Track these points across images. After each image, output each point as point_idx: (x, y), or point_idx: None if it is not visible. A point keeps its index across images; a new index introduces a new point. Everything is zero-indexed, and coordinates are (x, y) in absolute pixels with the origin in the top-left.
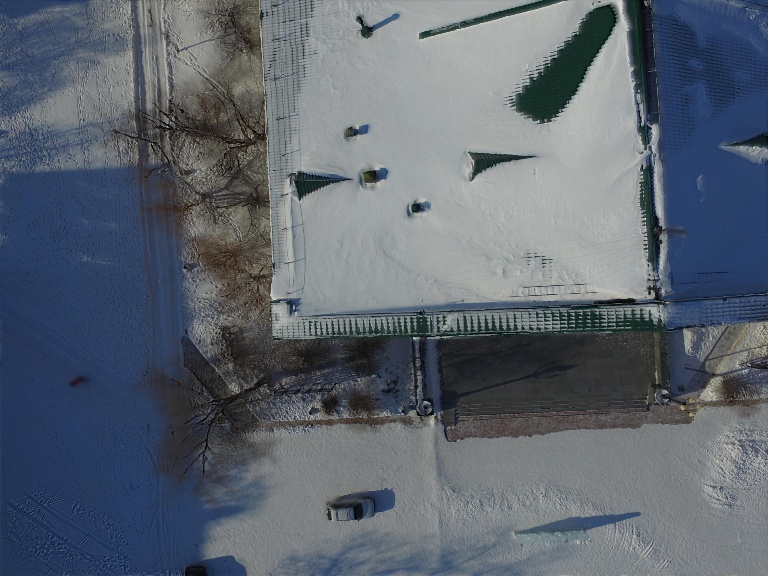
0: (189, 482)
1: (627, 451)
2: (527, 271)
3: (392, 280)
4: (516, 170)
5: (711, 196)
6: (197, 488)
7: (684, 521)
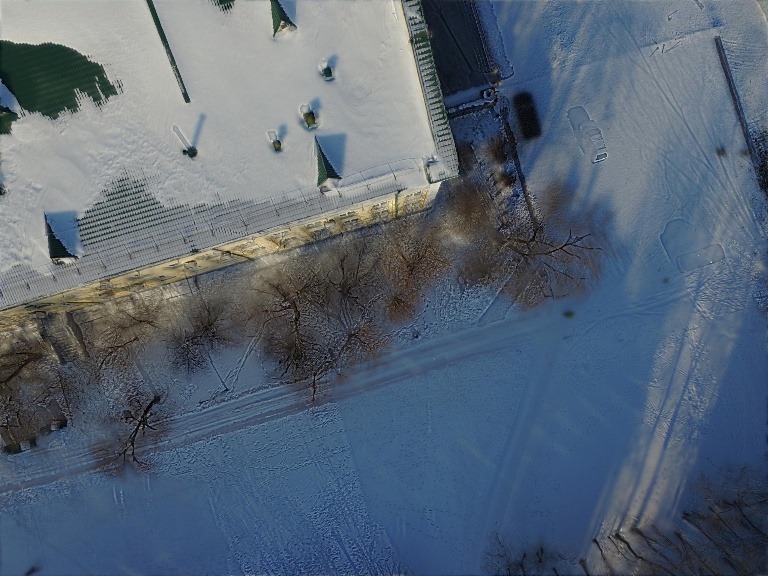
0: (605, 290)
1: None
2: None
3: (390, 81)
4: None
5: None
6: (608, 281)
7: None
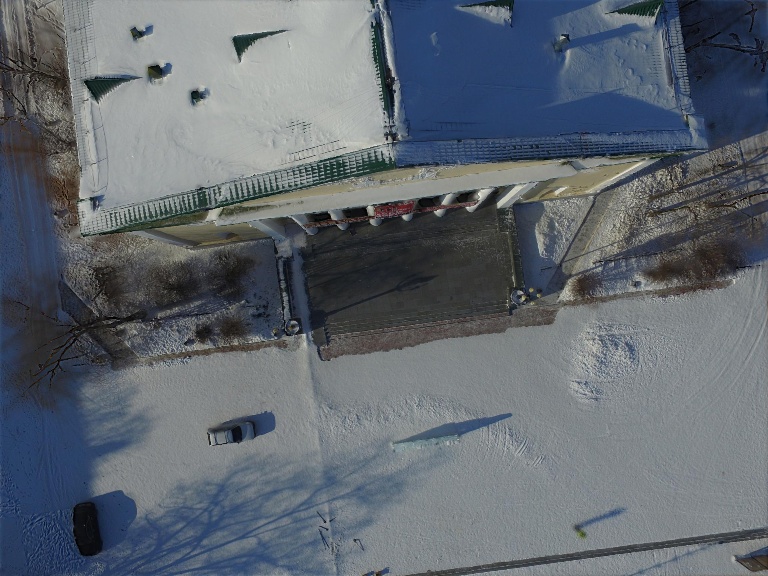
0: (74, 422)
1: (494, 355)
2: (291, 138)
3: (183, 167)
4: (274, 45)
5: (449, 52)
6: (82, 427)
7: (554, 418)
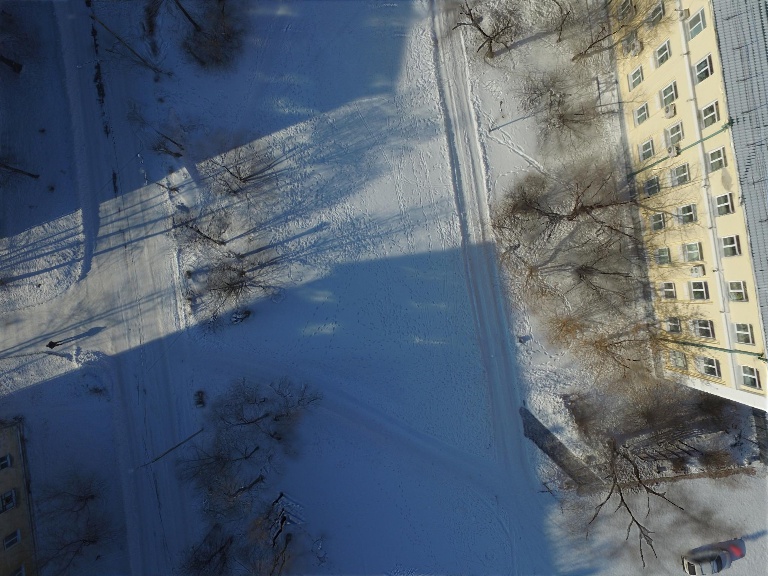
0: (542, 548)
1: None
2: None
3: None
4: None
5: None
6: (550, 553)
7: None
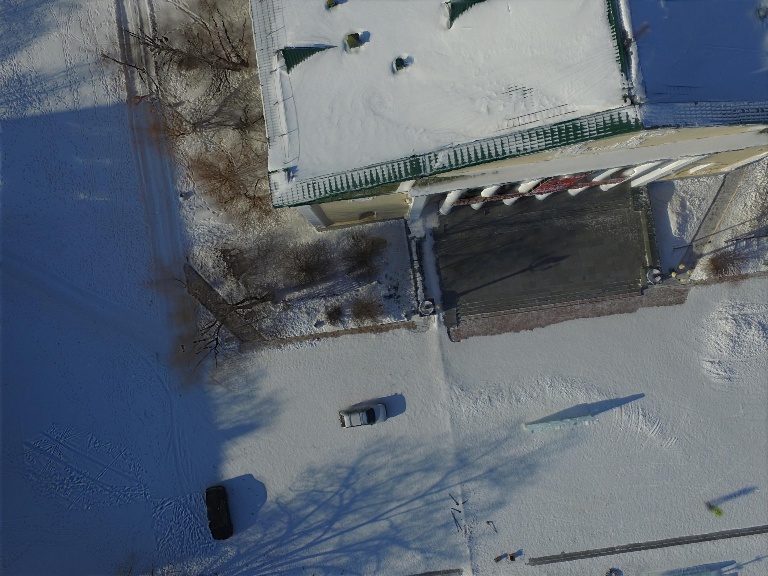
0: (202, 405)
1: (626, 335)
2: (510, 104)
3: (383, 136)
4: (491, 10)
5: (675, 14)
6: (210, 410)
7: (687, 398)
